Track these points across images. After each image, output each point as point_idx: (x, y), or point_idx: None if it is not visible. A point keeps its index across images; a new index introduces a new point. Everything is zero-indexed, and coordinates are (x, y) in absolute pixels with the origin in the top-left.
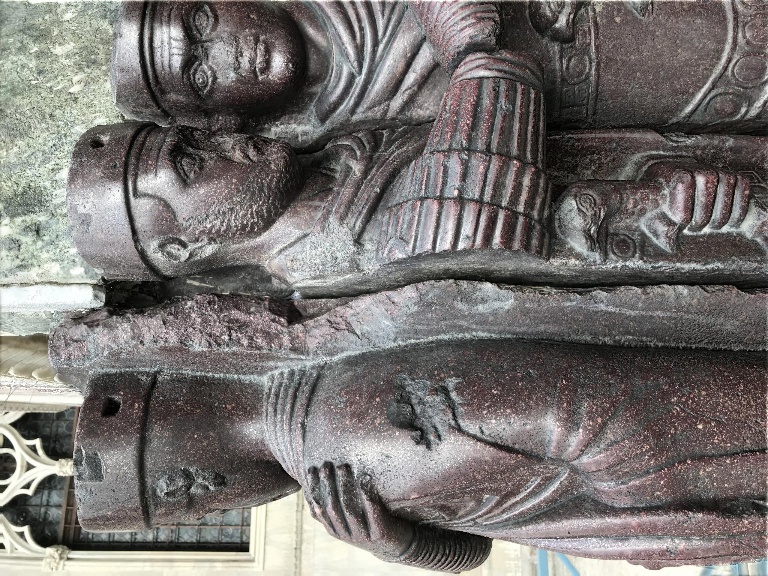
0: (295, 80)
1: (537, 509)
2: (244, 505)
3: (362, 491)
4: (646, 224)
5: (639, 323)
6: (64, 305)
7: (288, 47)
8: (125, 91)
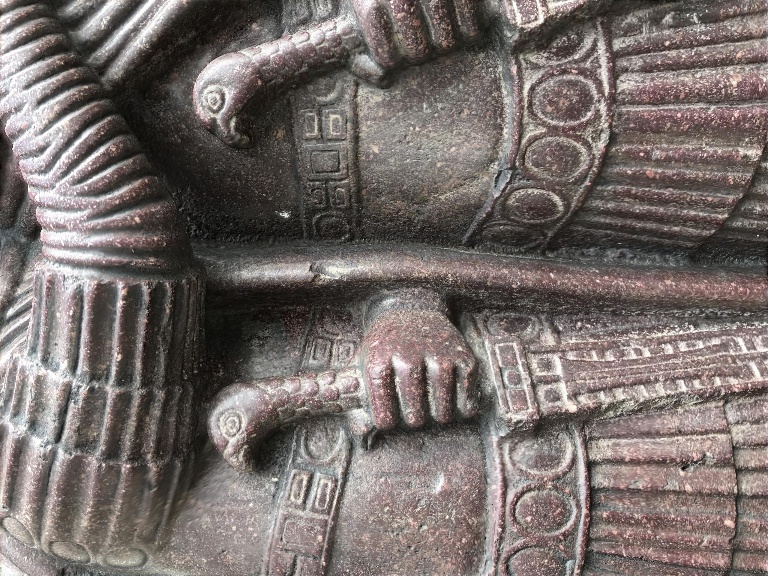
0: None
1: None
2: None
3: None
4: None
5: None
6: None
7: None
8: None
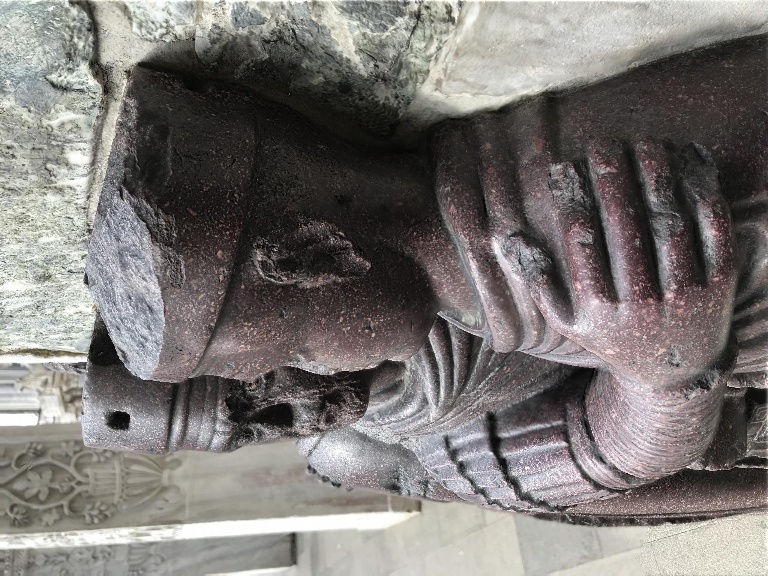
0: None
1: None
2: None
3: None
4: None
5: None
6: None
7: None
8: None
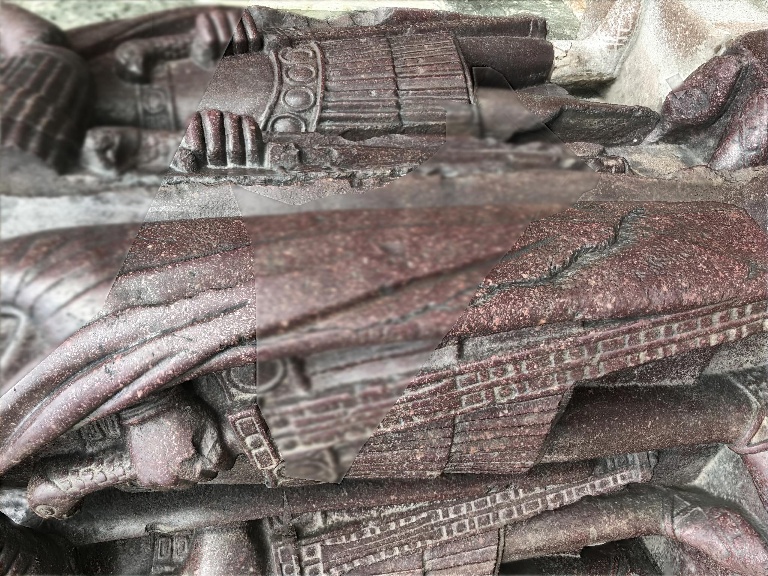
0: None
1: None
2: None
3: None
4: None
5: None
6: None
7: None
8: None
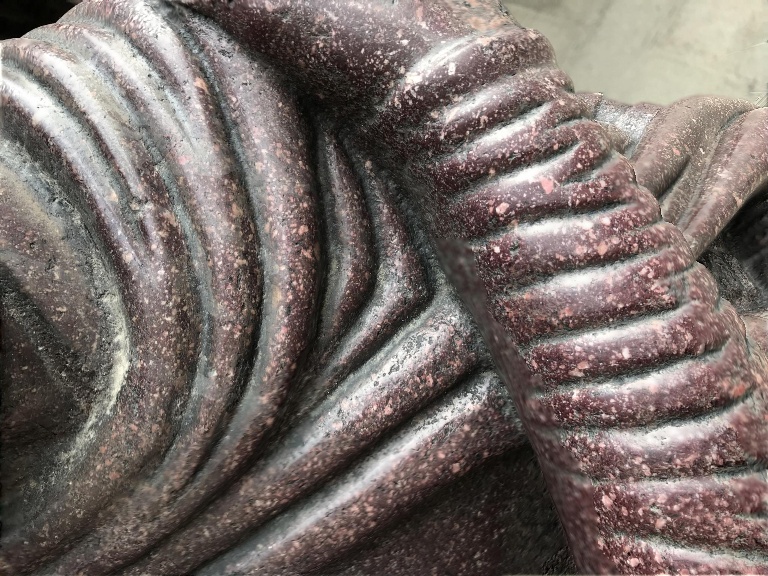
0: None
1: None
2: None
3: None
4: None
5: None
6: None
7: None
8: None
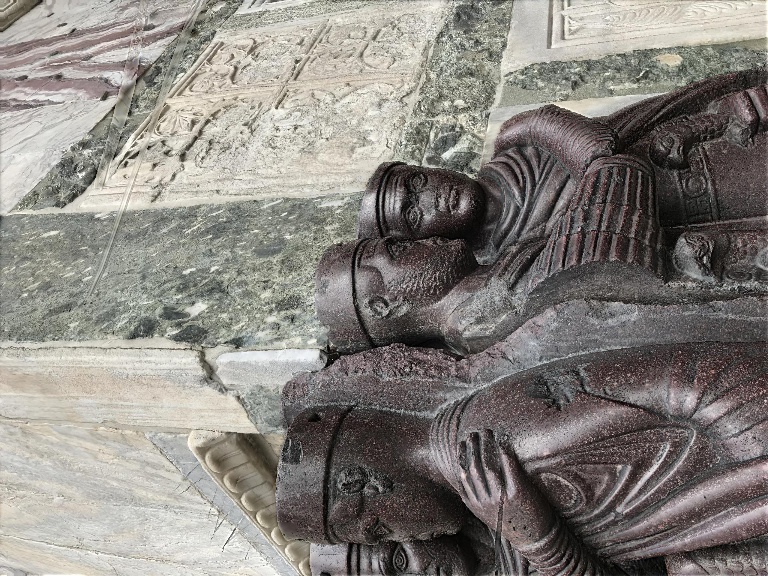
0: (477, 214)
1: (673, 485)
2: (407, 525)
3: (500, 447)
4: (760, 261)
5: (763, 329)
6: (298, 365)
7: (472, 192)
8: (364, 230)
